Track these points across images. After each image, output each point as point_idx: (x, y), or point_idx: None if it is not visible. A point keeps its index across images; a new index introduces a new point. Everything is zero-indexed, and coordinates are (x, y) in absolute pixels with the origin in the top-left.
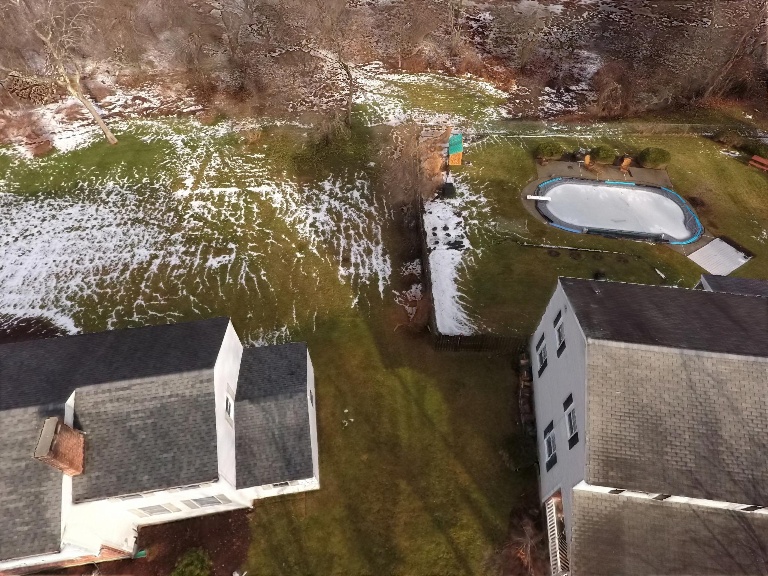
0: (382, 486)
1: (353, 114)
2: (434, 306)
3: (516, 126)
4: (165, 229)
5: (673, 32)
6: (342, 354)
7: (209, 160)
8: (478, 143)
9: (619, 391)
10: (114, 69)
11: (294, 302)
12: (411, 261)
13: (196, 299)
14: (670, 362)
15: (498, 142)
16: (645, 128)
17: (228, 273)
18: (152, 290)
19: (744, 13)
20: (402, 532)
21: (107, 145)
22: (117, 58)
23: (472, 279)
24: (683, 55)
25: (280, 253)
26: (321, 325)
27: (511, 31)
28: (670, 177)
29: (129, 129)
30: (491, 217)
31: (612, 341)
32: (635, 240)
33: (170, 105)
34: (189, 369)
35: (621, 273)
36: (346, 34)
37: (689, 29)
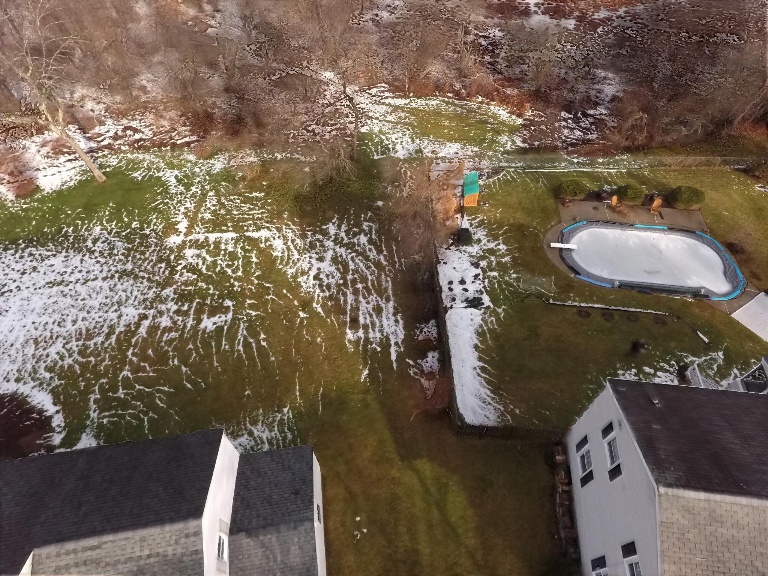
0: None
1: (358, 144)
2: (453, 380)
3: (533, 158)
4: (155, 283)
5: (693, 48)
6: (352, 444)
7: (204, 200)
8: (494, 180)
9: (700, 557)
10: (99, 107)
11: (297, 375)
12: (426, 322)
13: (188, 370)
14: (762, 518)
15: (515, 178)
16: (674, 161)
17: (224, 337)
18: (140, 359)
19: (766, 27)
20: None
21: (95, 183)
22: (103, 95)
23: (494, 346)
24: (705, 74)
25: (281, 312)
26: (328, 405)
27: (523, 49)
28: (705, 219)
29: (119, 164)
30: (512, 268)
31: (689, 490)
32: (672, 295)
33: (163, 136)
34: (172, 518)
35: (660, 338)
36: (349, 54)
37: (710, 45)
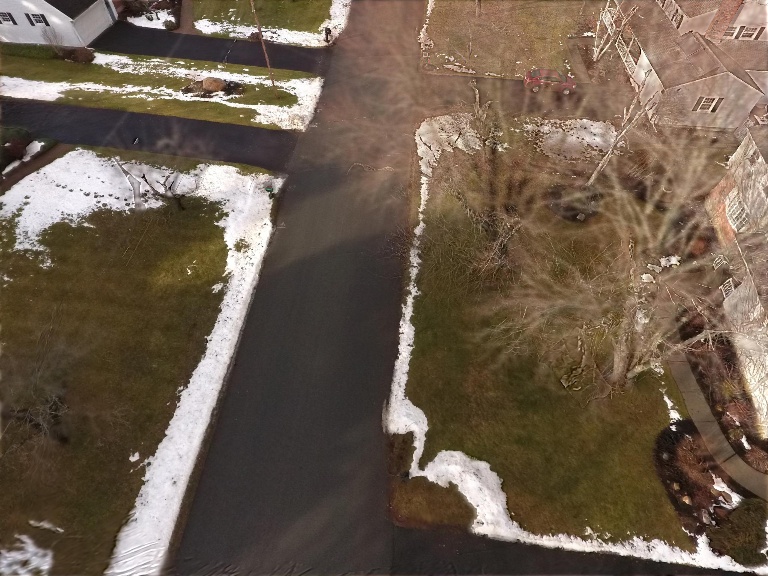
0: (611, 7)
1: None
2: None
3: None
4: None
5: None
6: None
7: None
8: None
9: None
10: None
11: None
12: None
13: None
14: None
15: None
16: None
17: None
18: None
19: None
20: (598, 8)
21: None
22: None
23: None
24: None
25: None
26: None
27: None
28: None
29: None
30: None
31: None
32: None
33: None
34: None
35: None
36: None
37: None
